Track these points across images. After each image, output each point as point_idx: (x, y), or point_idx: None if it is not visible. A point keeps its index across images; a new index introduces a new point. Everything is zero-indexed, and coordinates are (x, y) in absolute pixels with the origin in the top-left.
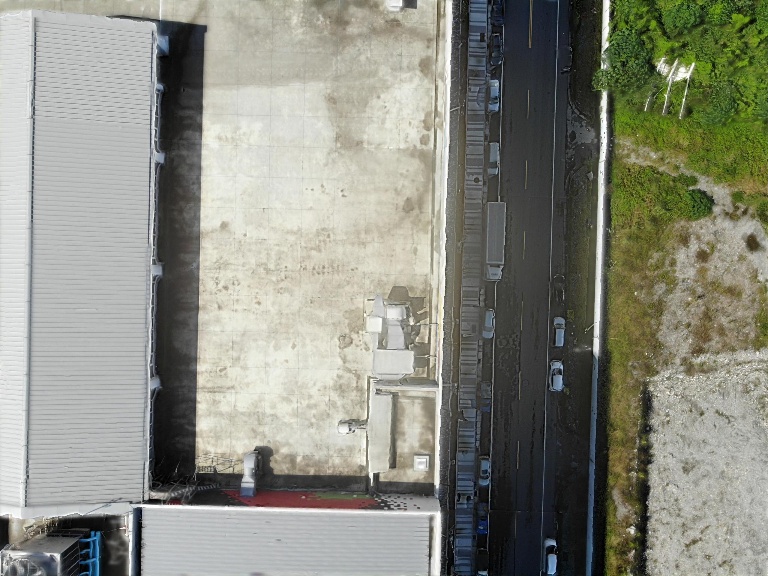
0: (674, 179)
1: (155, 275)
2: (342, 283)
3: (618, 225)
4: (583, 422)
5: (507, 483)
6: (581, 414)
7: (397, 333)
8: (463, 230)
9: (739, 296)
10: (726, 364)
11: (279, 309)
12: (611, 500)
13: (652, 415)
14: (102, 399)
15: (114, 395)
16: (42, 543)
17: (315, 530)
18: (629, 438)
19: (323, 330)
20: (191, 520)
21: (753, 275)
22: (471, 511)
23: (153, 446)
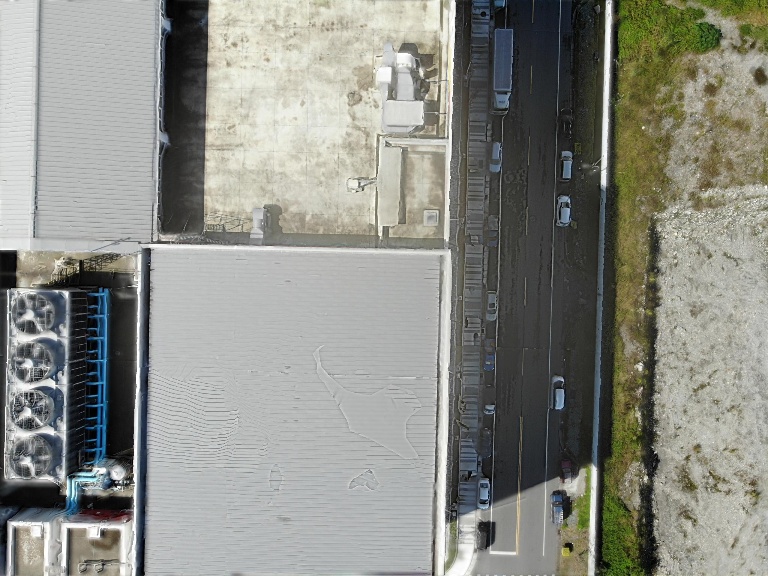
0: (682, 11)
1: (164, 28)
2: (351, 40)
3: (625, 58)
4: (591, 258)
5: (514, 320)
6: (589, 250)
7: (407, 82)
8: (470, 64)
9: (747, 130)
10: (734, 199)
11: (288, 66)
12: (619, 336)
13: (660, 257)
14: (111, 136)
15: (123, 133)
16: (50, 288)
17: (325, 271)
18: (637, 274)
19: (332, 87)
20: (200, 262)
21: (761, 109)
22: (478, 349)
23: (161, 203)
